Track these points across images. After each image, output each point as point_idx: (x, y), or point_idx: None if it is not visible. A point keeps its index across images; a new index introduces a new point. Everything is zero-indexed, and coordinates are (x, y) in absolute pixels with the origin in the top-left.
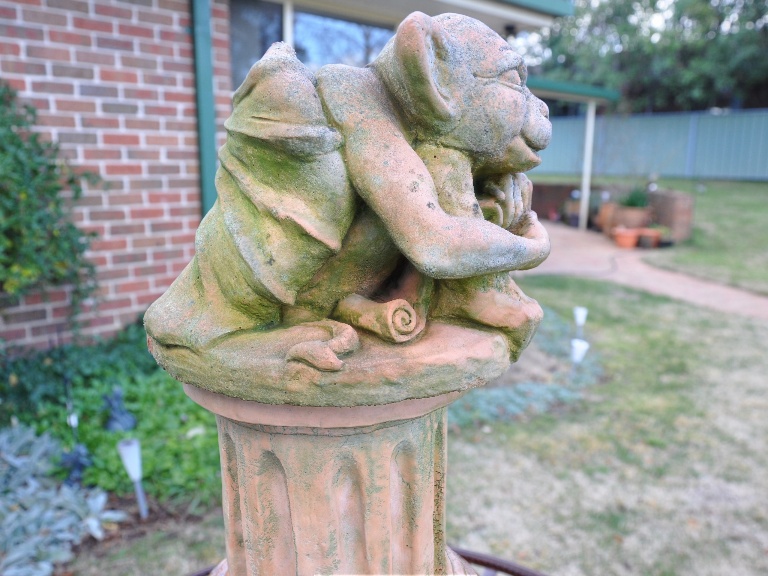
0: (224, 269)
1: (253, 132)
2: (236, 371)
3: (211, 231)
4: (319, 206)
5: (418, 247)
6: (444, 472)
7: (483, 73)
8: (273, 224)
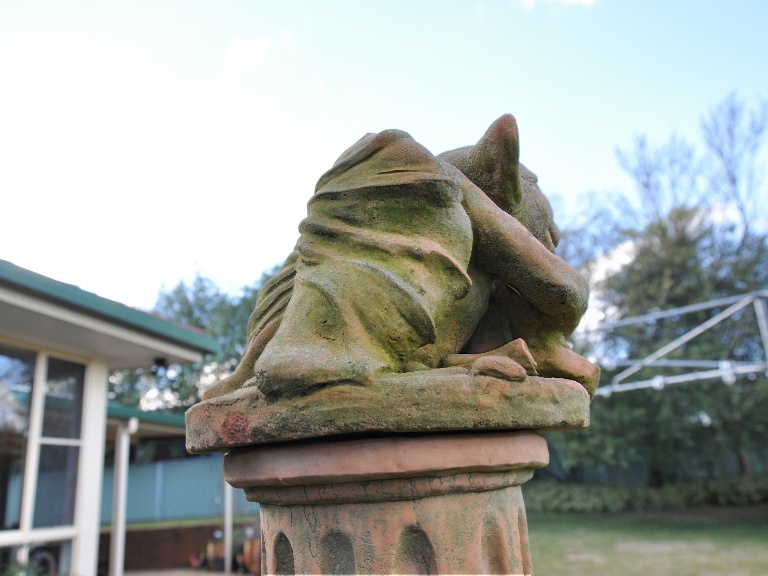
0: (370, 303)
1: (388, 182)
2: (424, 390)
3: (335, 276)
4: (454, 247)
5: (555, 273)
6: None
7: (527, 178)
8: (413, 262)
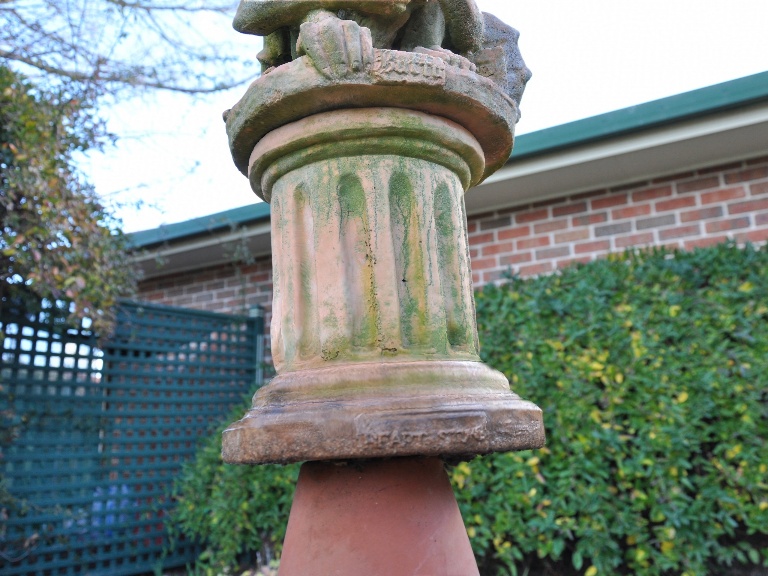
0: None
1: None
2: None
3: None
4: None
5: None
6: (371, 229)
7: None
8: None
